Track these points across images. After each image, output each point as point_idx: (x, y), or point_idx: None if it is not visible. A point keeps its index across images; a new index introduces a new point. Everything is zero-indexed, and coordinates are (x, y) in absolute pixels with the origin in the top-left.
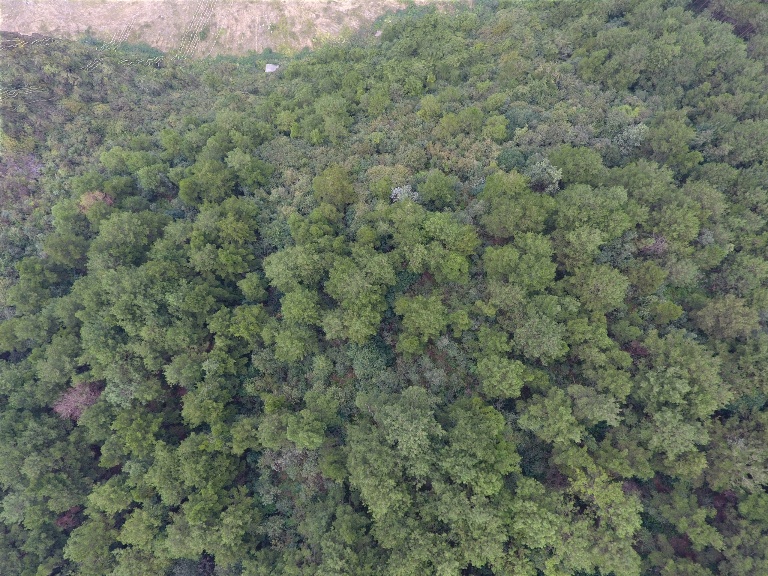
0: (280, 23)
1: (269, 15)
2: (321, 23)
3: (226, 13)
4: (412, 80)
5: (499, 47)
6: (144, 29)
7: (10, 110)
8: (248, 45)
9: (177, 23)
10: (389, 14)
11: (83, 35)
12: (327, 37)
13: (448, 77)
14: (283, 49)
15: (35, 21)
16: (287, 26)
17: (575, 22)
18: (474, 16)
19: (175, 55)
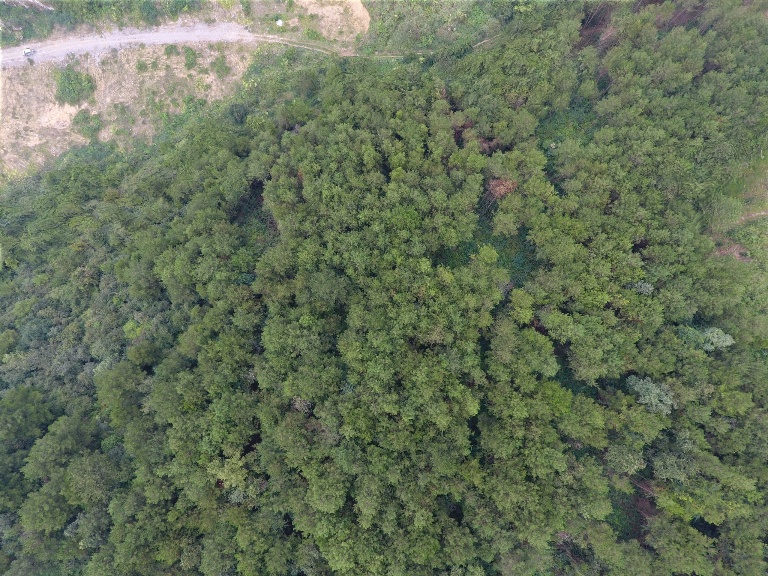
0: None
1: None
2: (9, 159)
3: None
4: None
5: (84, 227)
6: None
7: None
8: None
9: None
10: (71, 151)
11: None
12: (14, 174)
13: None
14: None
15: None
16: None
17: (150, 205)
18: (117, 170)
19: None
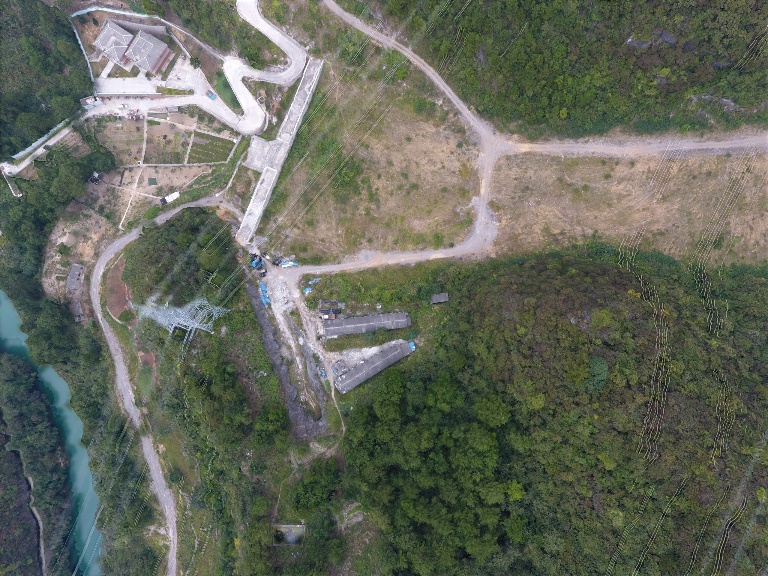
0: None
1: None
2: None
3: (741, 221)
4: None
5: None
6: (657, 237)
7: (742, 414)
8: (762, 254)
9: (692, 231)
10: None
11: (590, 239)
12: None
13: None
14: None
15: (538, 223)
16: None
17: None
18: None
19: (688, 263)
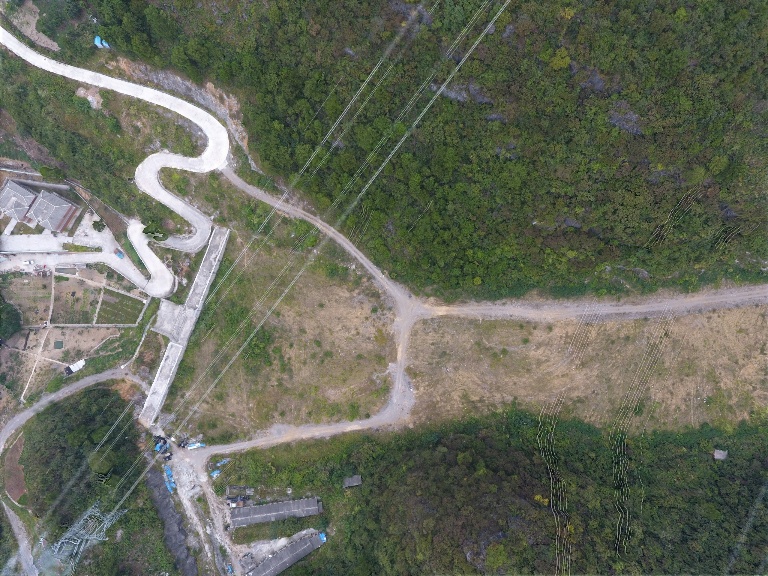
0: (717, 397)
1: (704, 388)
2: (758, 396)
3: (661, 387)
4: None
5: None
6: (577, 404)
7: None
8: (684, 419)
9: (612, 398)
10: None
11: (509, 407)
12: (767, 412)
13: None
14: (722, 425)
15: (457, 390)
16: (724, 400)
17: None
18: None
19: (609, 431)
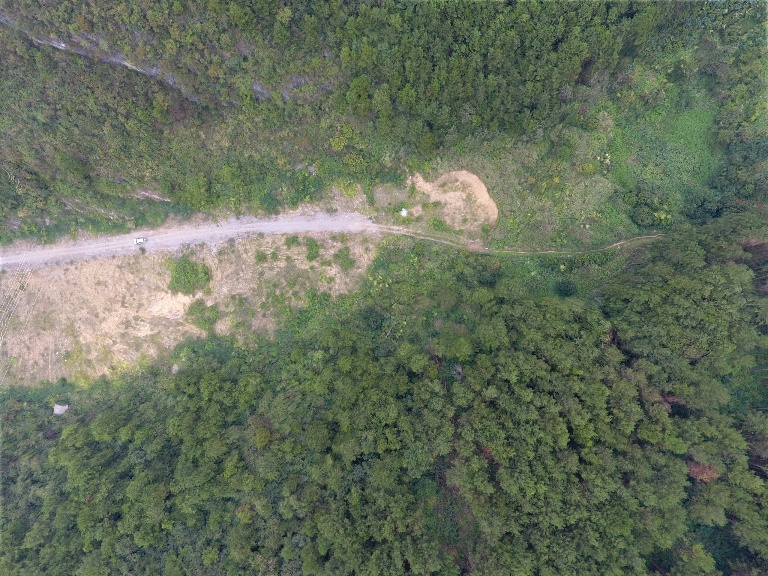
0: (74, 351)
1: (63, 342)
2: (118, 350)
3: (17, 341)
4: (141, 536)
5: (243, 484)
6: None
7: None
8: (41, 375)
9: None
10: (187, 345)
11: None
12: (124, 366)
13: (186, 522)
14: (77, 380)
15: None
16: (82, 354)
17: (319, 467)
18: (253, 387)
19: None
